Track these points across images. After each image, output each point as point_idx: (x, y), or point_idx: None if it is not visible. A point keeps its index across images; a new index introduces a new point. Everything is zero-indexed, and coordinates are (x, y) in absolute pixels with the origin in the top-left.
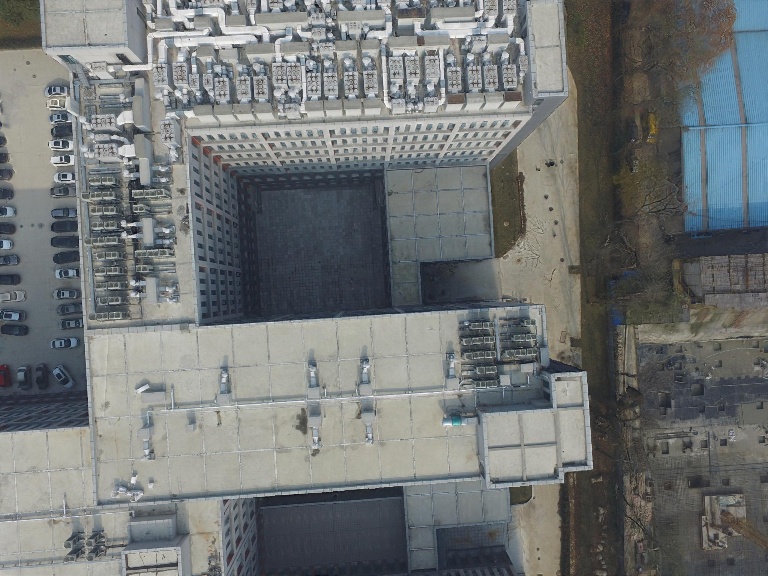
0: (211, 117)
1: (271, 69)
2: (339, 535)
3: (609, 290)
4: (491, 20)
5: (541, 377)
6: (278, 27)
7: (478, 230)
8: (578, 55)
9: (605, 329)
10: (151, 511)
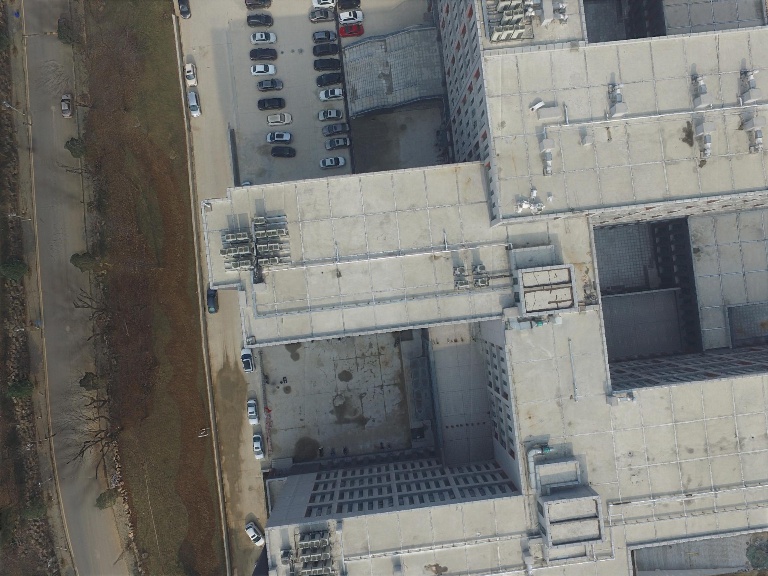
0: None
1: None
2: (617, 330)
3: None
4: None
5: None
6: None
7: (750, 15)
8: None
9: None
10: (525, 244)
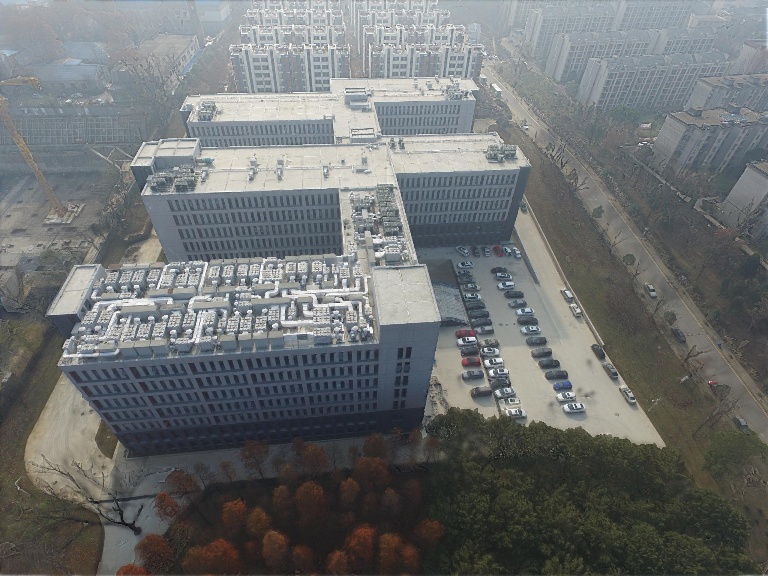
0: None
1: None
2: None
3: None
4: (110, 308)
5: None
6: None
7: None
8: (7, 476)
9: None
10: None
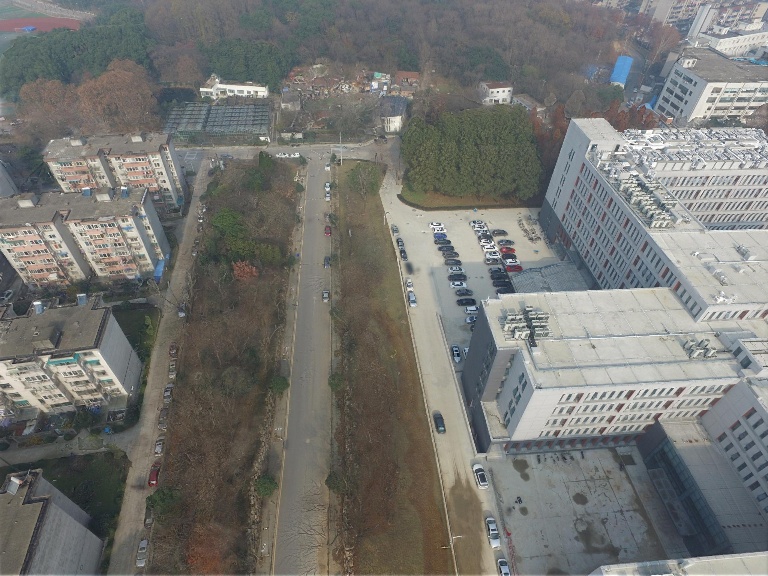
0: (663, 165)
1: None
2: None
3: None
4: None
5: None
6: (673, 145)
7: None
8: None
9: None
10: None
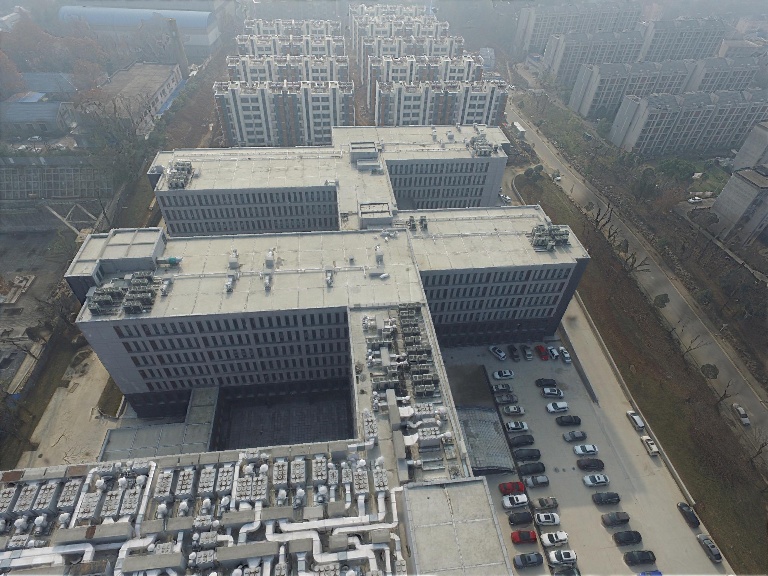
0: None
1: (272, 506)
2: None
3: (7, 425)
4: None
5: (101, 283)
6: None
7: (116, 455)
8: None
9: (30, 395)
10: None
